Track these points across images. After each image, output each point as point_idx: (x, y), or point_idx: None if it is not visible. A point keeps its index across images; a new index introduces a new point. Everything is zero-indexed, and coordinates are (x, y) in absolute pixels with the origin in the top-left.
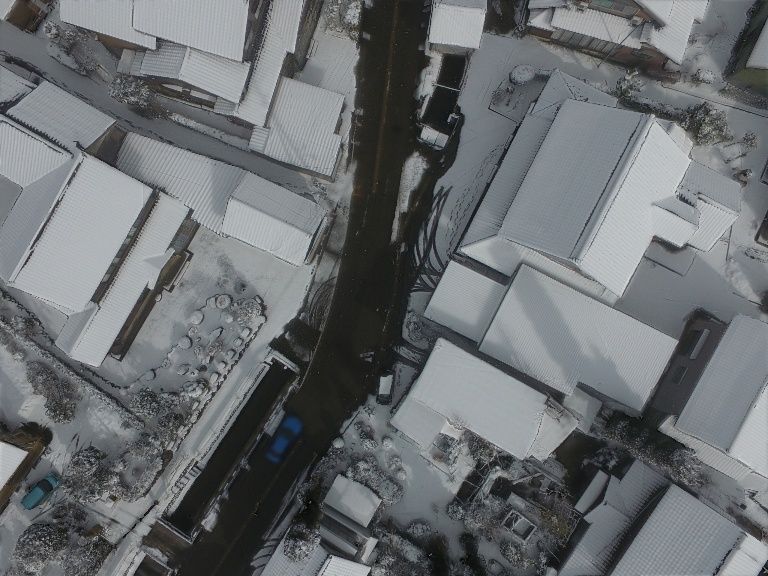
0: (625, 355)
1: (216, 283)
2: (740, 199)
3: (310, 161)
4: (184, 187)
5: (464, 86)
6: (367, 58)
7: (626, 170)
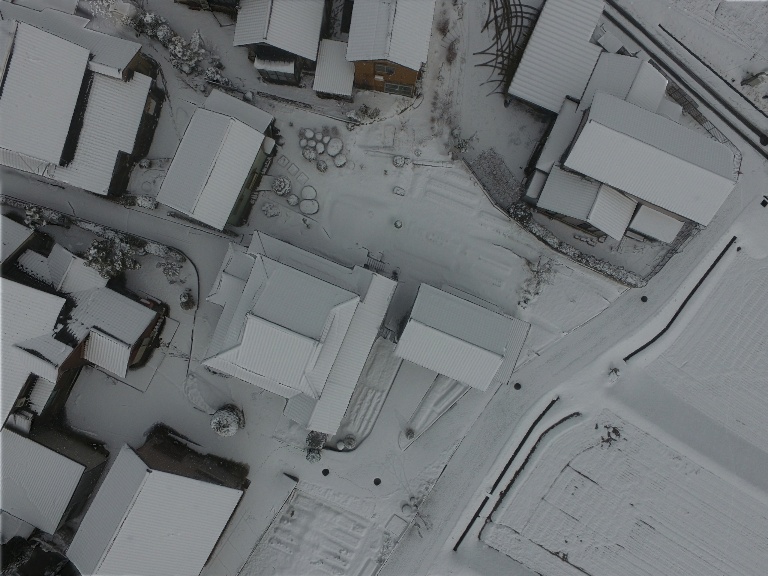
0: (35, 481)
1: None
2: (144, 330)
3: None
4: None
5: None
6: None
7: None
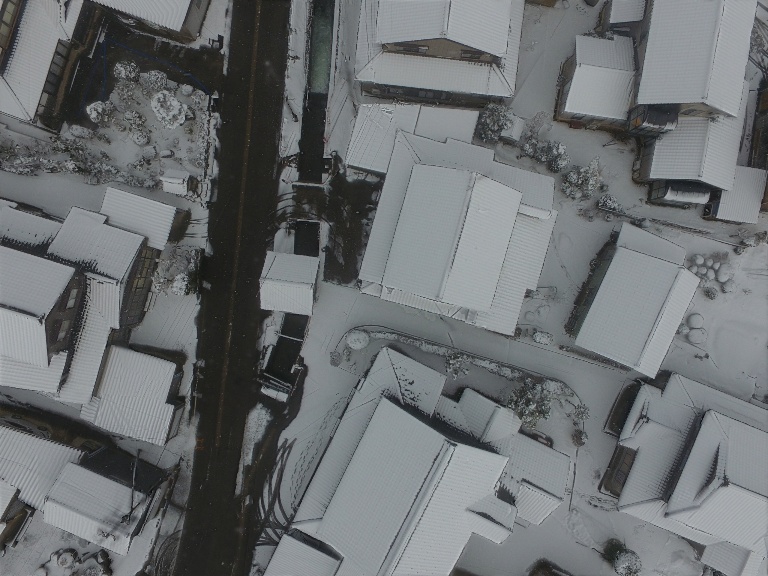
0: None
1: (60, 537)
2: (567, 479)
3: (142, 432)
4: (9, 468)
5: (304, 341)
6: (208, 308)
7: (427, 499)
